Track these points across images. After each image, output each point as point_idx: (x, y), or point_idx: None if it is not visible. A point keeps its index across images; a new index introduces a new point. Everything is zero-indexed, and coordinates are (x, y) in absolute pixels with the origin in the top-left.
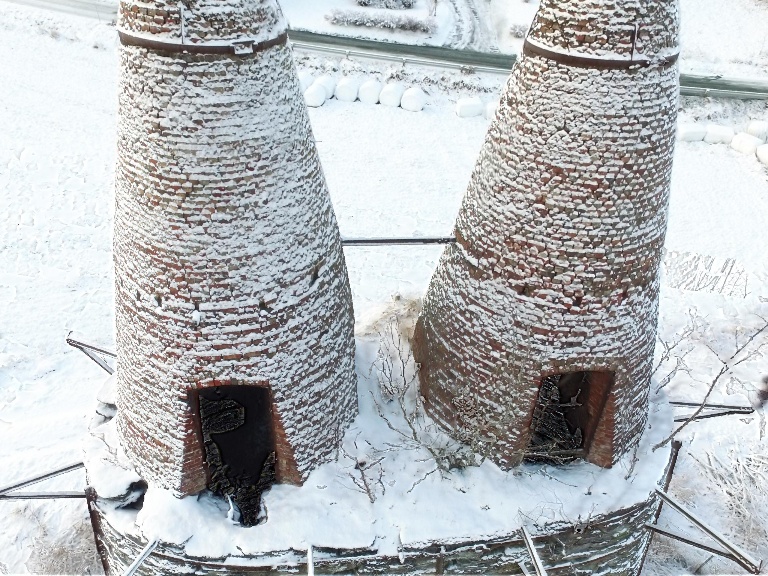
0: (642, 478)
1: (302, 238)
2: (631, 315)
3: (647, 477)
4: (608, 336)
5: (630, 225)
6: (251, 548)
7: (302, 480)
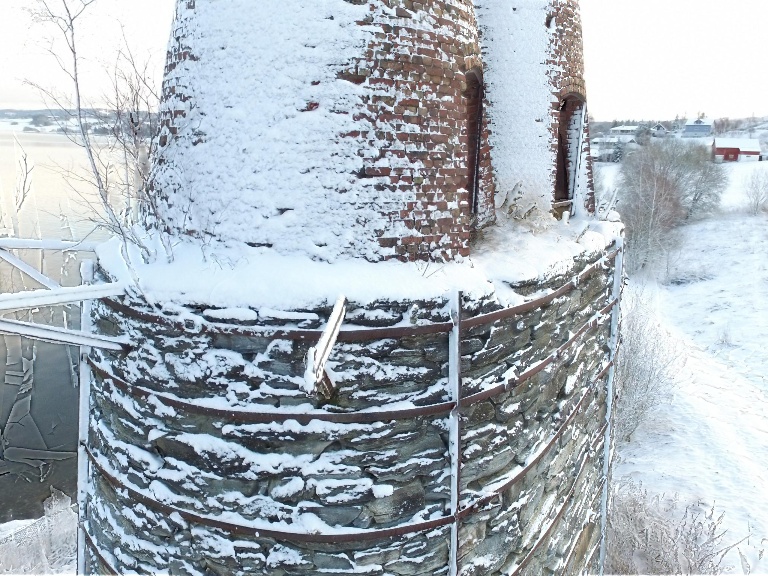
0: None
1: None
2: None
3: None
4: None
5: None
6: None
7: None
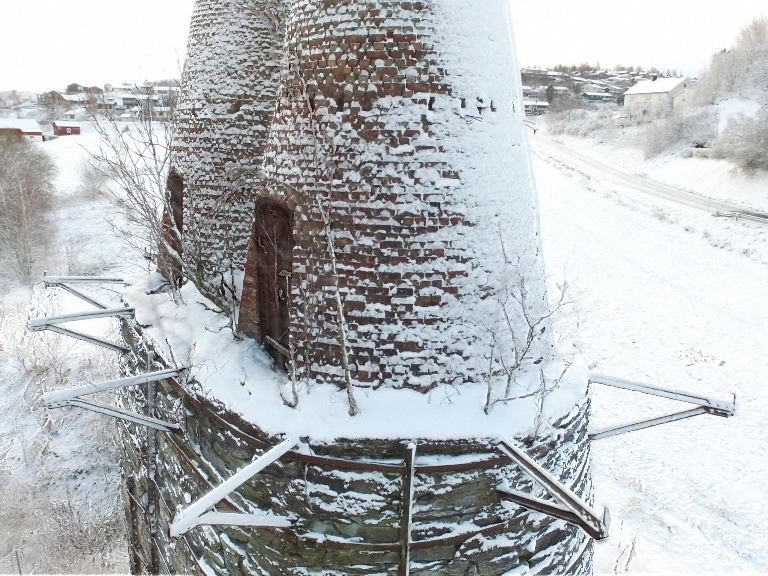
0: (298, 417)
1: (233, 71)
2: (318, 137)
3: (303, 420)
4: (291, 156)
5: (318, 8)
6: (126, 296)
7: (183, 282)
